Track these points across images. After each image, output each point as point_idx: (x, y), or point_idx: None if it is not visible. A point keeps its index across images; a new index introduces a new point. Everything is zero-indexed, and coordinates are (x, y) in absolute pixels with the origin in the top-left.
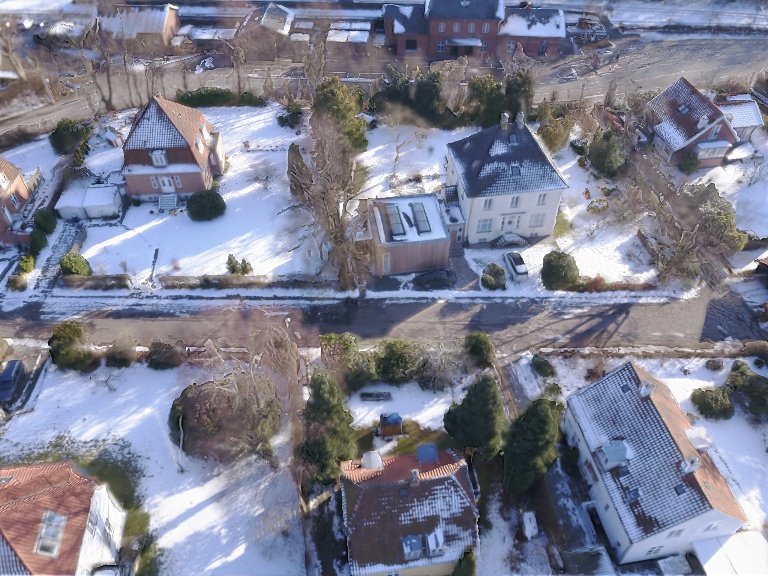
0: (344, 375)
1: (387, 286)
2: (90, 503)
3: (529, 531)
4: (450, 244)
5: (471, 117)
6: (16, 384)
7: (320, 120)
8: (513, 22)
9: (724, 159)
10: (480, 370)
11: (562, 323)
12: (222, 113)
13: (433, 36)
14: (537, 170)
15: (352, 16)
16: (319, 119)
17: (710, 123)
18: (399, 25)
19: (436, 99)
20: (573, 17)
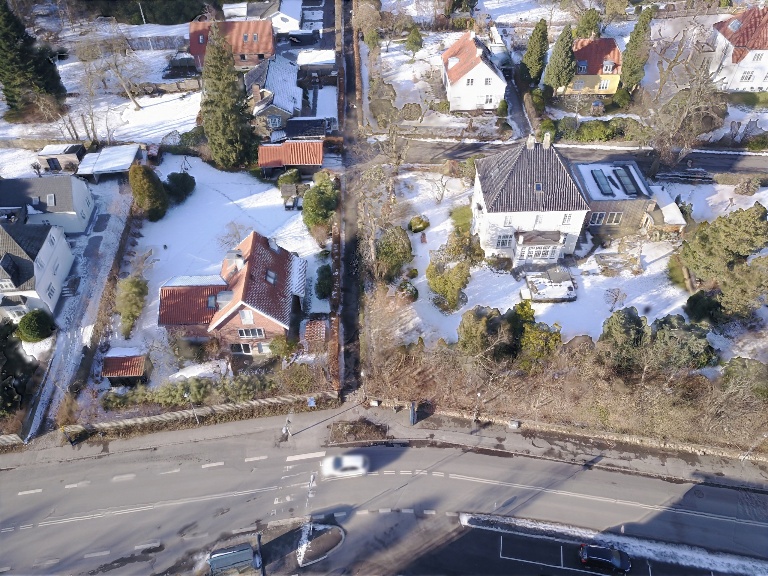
0: None
1: None
2: None
3: None
4: None
5: None
6: None
7: None
8: None
9: None
10: None
11: None
12: None
13: None
14: None
15: None
16: None
17: None
18: None
19: None
20: None
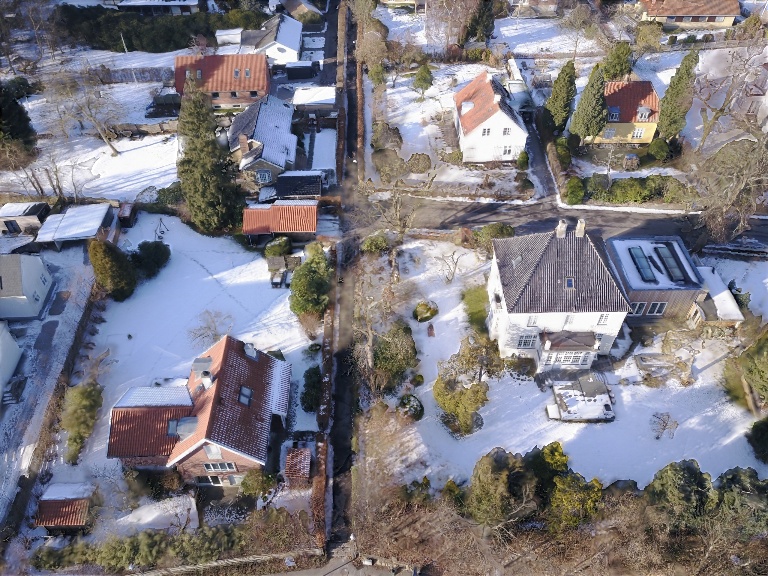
0: None
1: None
2: None
3: None
4: None
5: None
6: None
7: None
8: None
9: None
10: None
11: (500, 219)
12: None
13: None
14: None
15: None
16: None
17: None
18: None
19: None
20: None
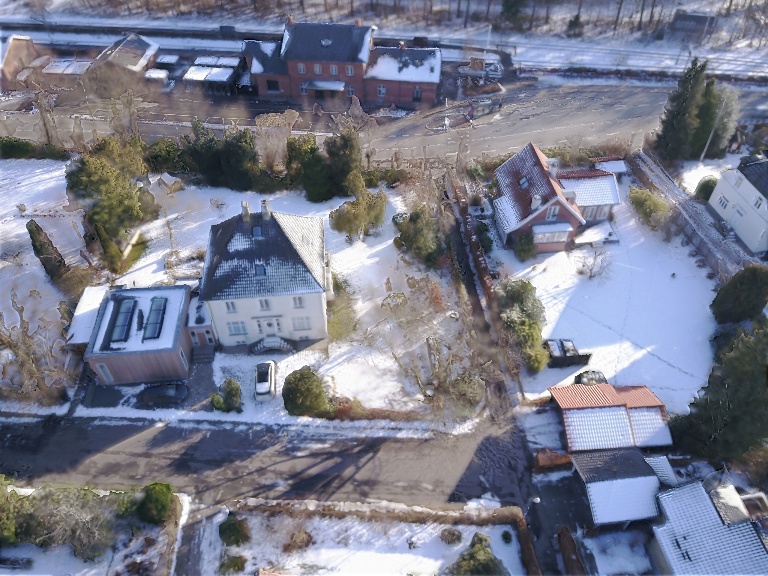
0: None
1: (104, 401)
2: None
3: None
4: (200, 347)
5: (291, 181)
6: None
7: (71, 192)
8: (383, 64)
9: (571, 242)
10: (159, 529)
11: (291, 463)
12: (16, 167)
13: (294, 77)
14: (287, 269)
15: (232, 48)
16: (70, 190)
17: (543, 204)
18: (257, 64)
19: (247, 160)
20: (472, 55)
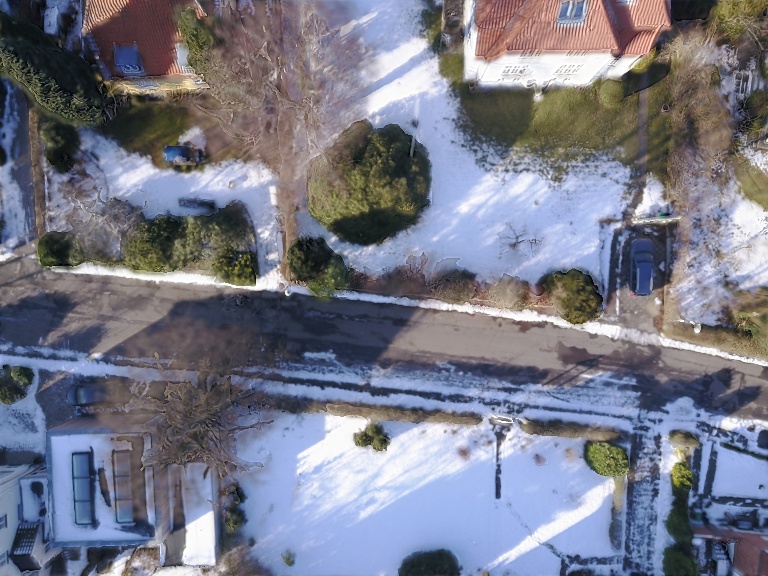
0: (227, 221)
1: None
2: (475, 1)
3: (54, 13)
4: None
5: None
6: (631, 260)
7: None
8: None
9: None
10: None
11: None
12: None
13: None
14: None
15: None
16: None
17: None
18: None
19: None
20: None
